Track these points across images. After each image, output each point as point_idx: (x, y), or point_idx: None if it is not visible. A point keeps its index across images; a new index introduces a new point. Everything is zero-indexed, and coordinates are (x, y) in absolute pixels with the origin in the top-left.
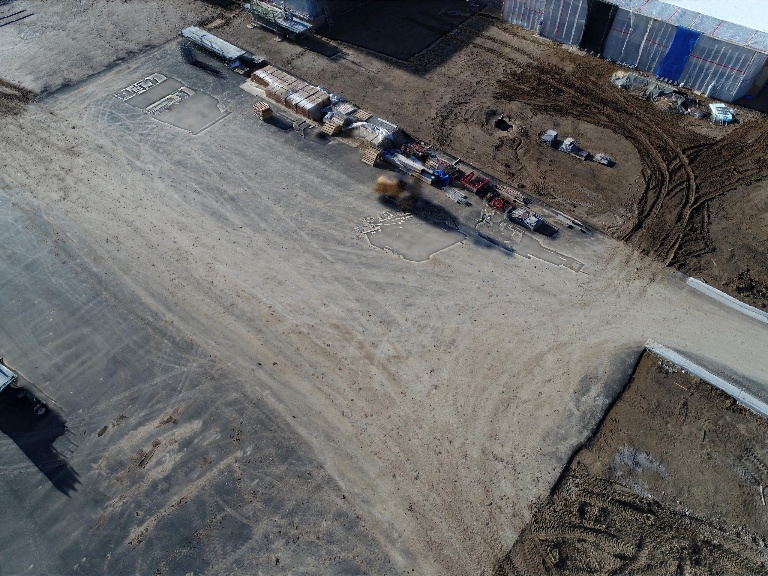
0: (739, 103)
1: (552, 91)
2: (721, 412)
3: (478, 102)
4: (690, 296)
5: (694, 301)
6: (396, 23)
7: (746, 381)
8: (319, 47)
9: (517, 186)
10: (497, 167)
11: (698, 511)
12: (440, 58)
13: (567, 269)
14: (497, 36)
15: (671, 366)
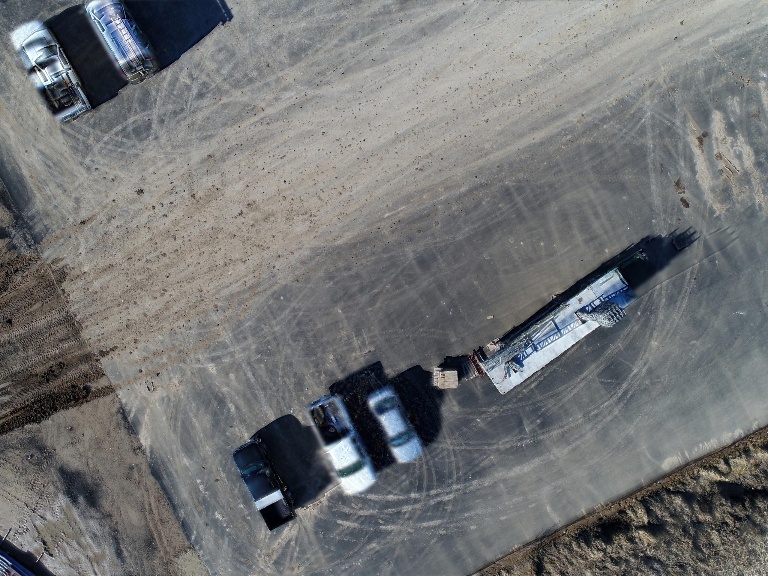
0: None
1: None
2: None
3: None
4: None
5: None
6: None
7: None
8: None
9: None
10: None
11: None
12: None
13: None
14: None
15: None
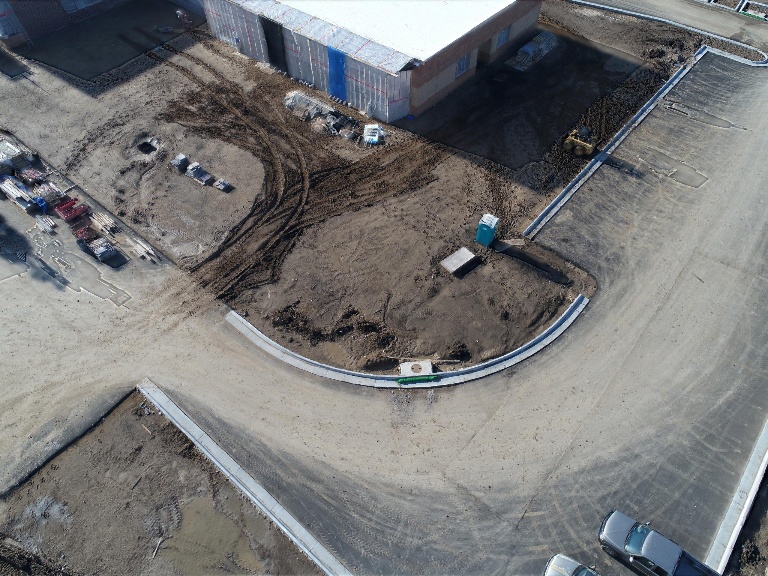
0: (397, 124)
1: (218, 112)
2: (171, 457)
3: (134, 124)
4: (219, 331)
5: (220, 336)
6: (103, 40)
7: (217, 423)
8: (8, 66)
9: (117, 214)
10: (110, 193)
11: (78, 566)
12: (125, 77)
13: (110, 303)
14: (196, 54)
15: (151, 407)
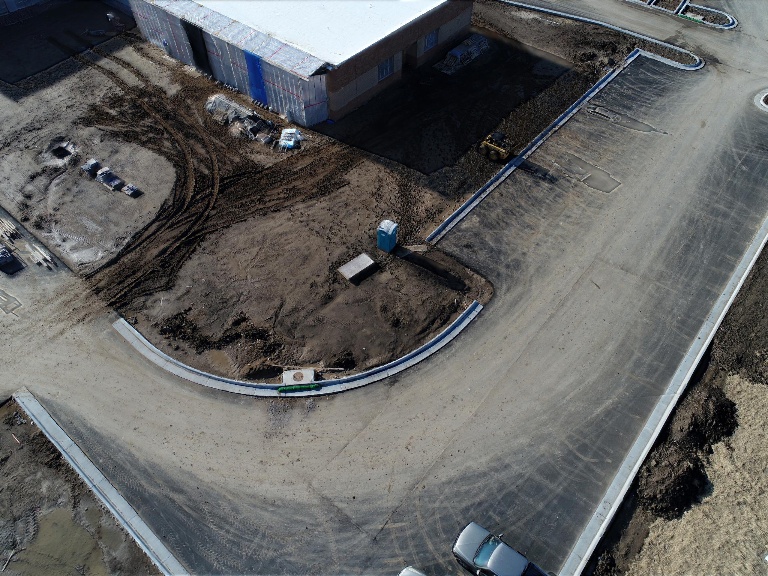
0: (315, 128)
1: (138, 116)
2: (37, 467)
3: (52, 128)
4: (105, 339)
5: (105, 344)
6: (33, 43)
7: (88, 432)
8: None
9: (20, 219)
10: (17, 199)
11: None
12: (50, 81)
13: None
14: (125, 57)
15: (24, 417)
